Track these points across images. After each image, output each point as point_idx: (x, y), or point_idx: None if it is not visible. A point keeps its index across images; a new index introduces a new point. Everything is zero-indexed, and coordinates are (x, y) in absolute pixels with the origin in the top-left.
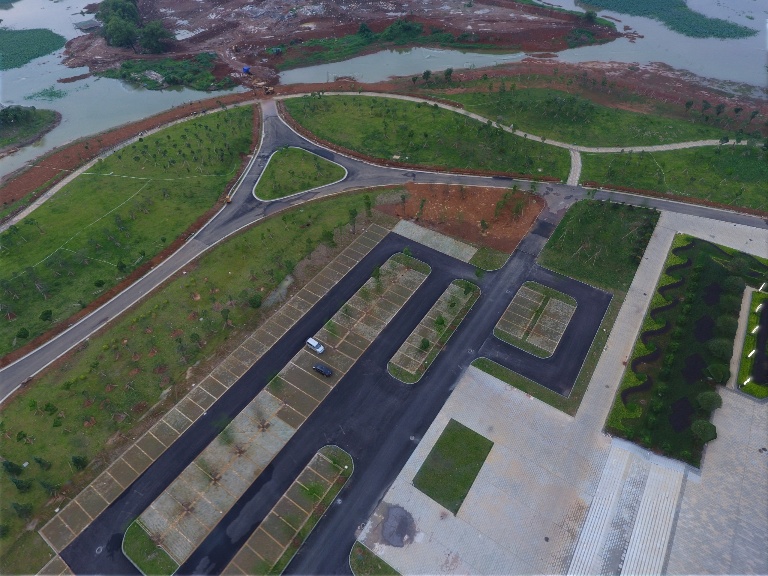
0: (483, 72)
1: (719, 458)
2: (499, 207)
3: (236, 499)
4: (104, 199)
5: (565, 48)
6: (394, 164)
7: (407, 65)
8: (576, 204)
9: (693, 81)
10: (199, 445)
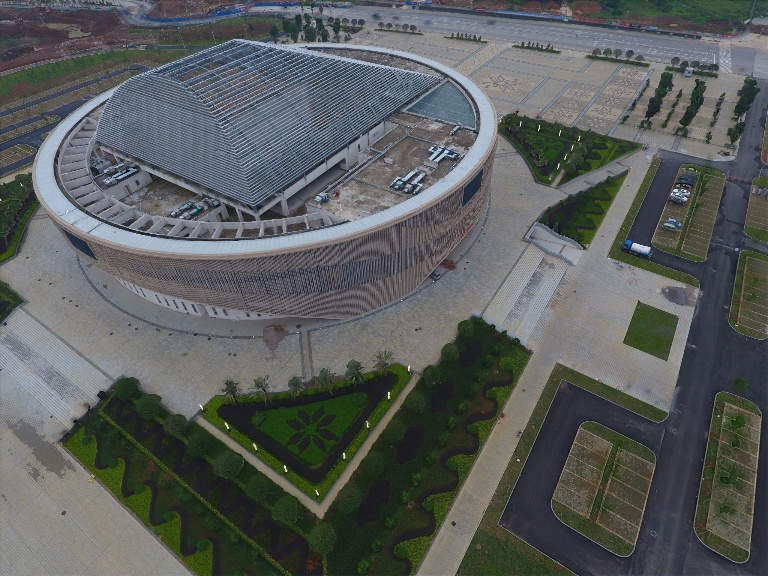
0: None
1: (454, 324)
2: None
3: None
4: None
5: None
6: None
7: None
8: None
9: None
10: None
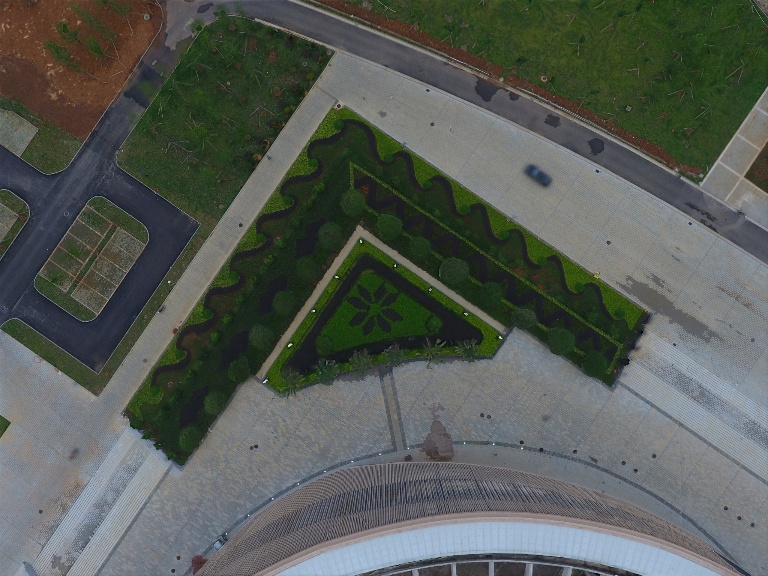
0: None
1: (208, 454)
2: None
3: None
4: None
5: None
6: None
7: None
8: (207, 30)
9: None
10: None
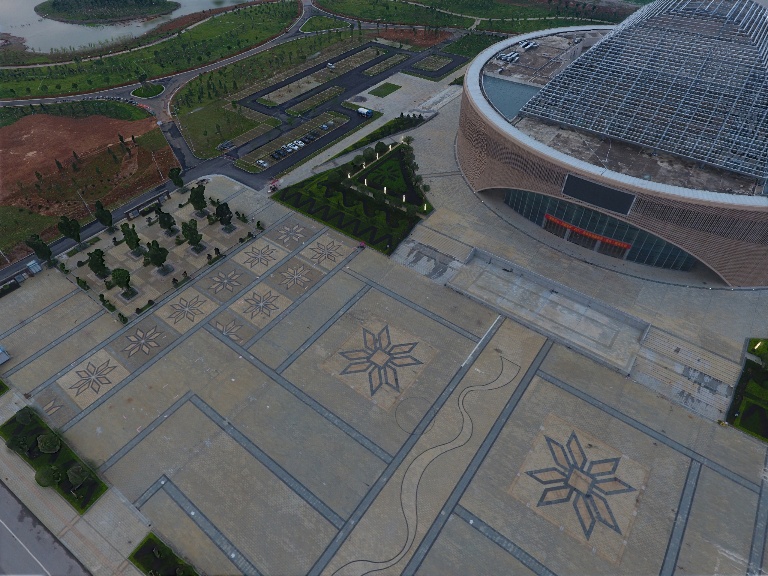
0: None
1: None
2: (428, 35)
3: (298, 95)
4: (220, 29)
5: None
6: None
7: None
8: (468, 34)
9: None
10: None
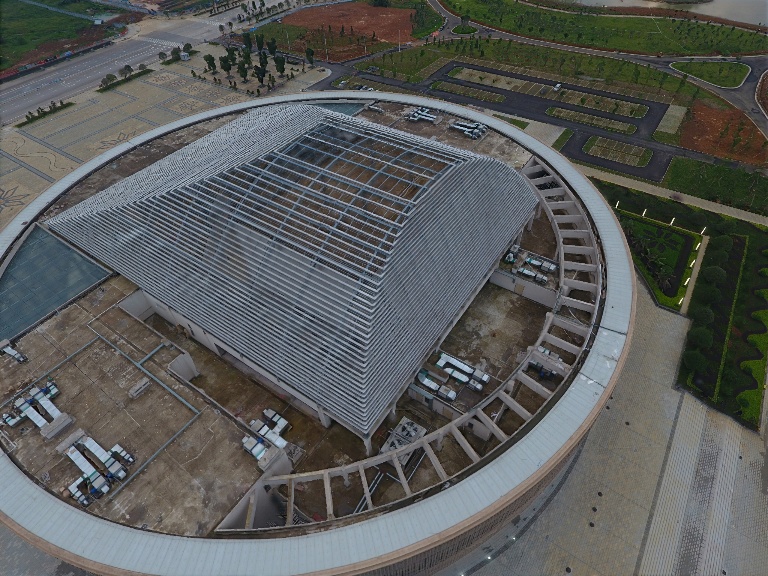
0: None
1: None
2: None
3: (477, 82)
4: (632, 27)
5: None
6: (765, 103)
7: None
8: None
9: None
10: (496, 73)
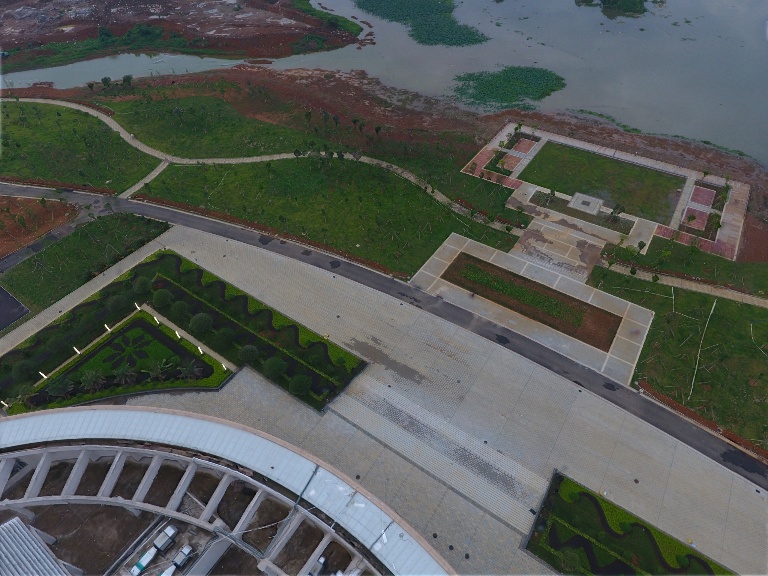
0: (178, 79)
1: None
2: None
3: None
4: None
5: (288, 54)
6: None
7: (122, 70)
8: (99, 217)
9: (370, 90)
10: None
